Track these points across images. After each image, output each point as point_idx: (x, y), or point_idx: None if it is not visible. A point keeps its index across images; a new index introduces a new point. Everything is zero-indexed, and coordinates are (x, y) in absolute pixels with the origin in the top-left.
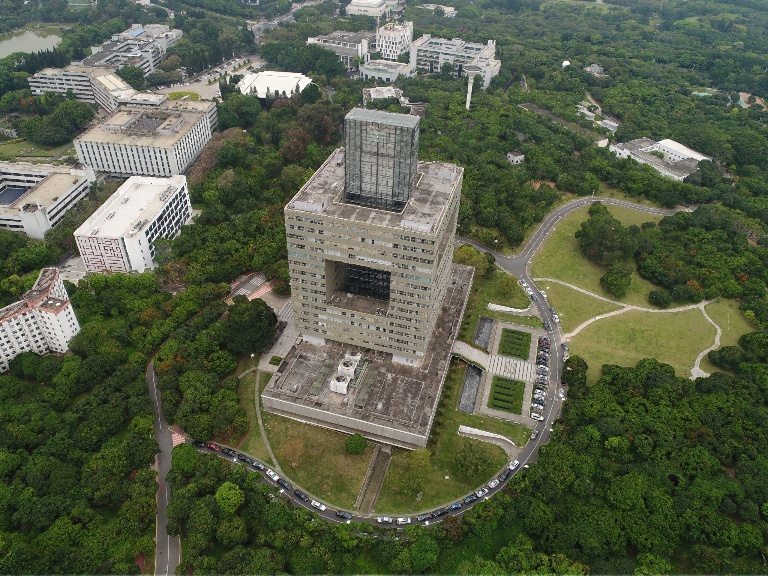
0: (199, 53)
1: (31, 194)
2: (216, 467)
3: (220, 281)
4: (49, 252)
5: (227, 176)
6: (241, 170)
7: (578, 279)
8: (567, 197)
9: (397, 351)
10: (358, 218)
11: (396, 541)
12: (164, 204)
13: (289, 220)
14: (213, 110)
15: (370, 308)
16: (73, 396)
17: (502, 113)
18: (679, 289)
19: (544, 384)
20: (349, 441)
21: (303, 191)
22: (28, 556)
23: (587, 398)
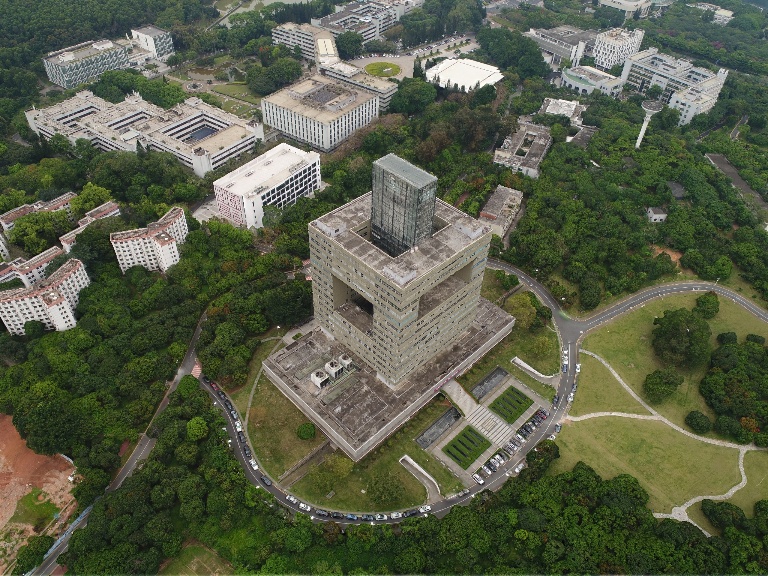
0: (420, 28)
1: (210, 139)
2: (200, 403)
3: (298, 255)
4: (199, 190)
5: (356, 162)
6: (377, 158)
7: (626, 367)
8: (685, 275)
9: (378, 370)
10: (357, 251)
11: (283, 519)
12: (289, 175)
13: (311, 234)
14: (393, 91)
15: (365, 326)
16: (150, 310)
17: (672, 161)
18: (723, 421)
19: (509, 453)
20: (302, 426)
21: (335, 212)
22: (58, 409)
23: (533, 484)
